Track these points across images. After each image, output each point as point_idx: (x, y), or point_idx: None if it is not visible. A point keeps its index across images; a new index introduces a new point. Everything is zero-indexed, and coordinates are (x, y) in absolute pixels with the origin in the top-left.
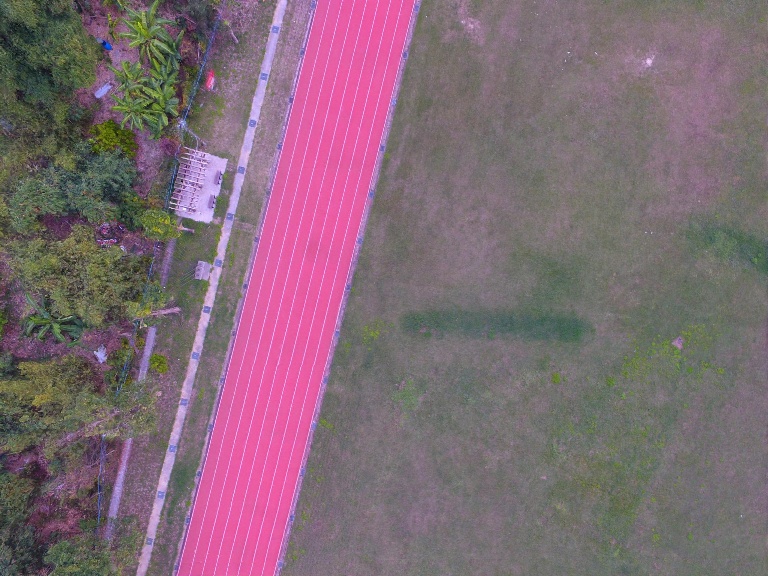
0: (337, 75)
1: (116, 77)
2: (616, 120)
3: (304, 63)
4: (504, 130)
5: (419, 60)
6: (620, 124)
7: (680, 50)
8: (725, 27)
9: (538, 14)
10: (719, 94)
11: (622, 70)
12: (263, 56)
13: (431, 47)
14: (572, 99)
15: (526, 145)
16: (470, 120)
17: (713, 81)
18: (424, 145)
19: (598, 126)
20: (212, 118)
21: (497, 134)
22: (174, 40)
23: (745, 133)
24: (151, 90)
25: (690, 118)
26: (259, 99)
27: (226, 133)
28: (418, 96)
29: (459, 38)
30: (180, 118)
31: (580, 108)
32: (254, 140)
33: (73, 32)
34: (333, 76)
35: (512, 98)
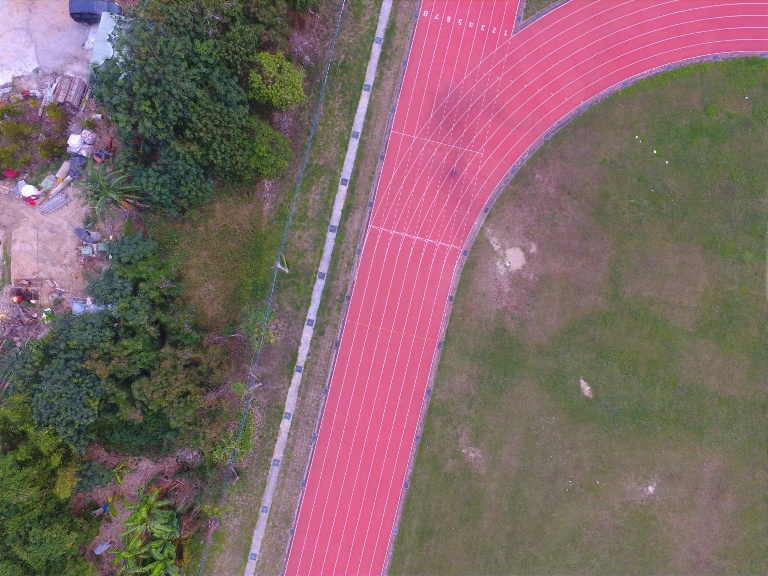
0: (338, 507)
1: (116, 534)
2: (618, 548)
3: (305, 496)
4: (506, 560)
5: (420, 490)
6: (622, 552)
7: (682, 478)
8: (726, 455)
9: (539, 444)
10: (721, 521)
11: (624, 498)
12: (264, 489)
13: (432, 477)
14: (574, 528)
15: (528, 574)
16: (472, 550)
17: (715, 508)
18: (426, 575)
19: (600, 554)
20: (213, 554)
21: (499, 563)
22: (175, 510)
23: (748, 560)
24: (151, 564)
25: (693, 545)
26: (260, 532)
27: (227, 567)
28: (419, 526)
29: (460, 467)
30: (180, 567)
31: (582, 537)
32: (255, 573)
33: (73, 567)
34: (334, 508)
35: (514, 528)
